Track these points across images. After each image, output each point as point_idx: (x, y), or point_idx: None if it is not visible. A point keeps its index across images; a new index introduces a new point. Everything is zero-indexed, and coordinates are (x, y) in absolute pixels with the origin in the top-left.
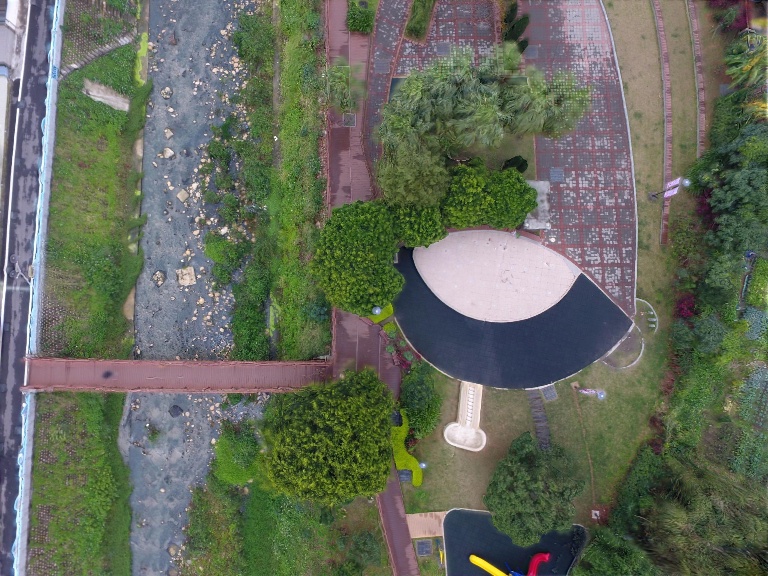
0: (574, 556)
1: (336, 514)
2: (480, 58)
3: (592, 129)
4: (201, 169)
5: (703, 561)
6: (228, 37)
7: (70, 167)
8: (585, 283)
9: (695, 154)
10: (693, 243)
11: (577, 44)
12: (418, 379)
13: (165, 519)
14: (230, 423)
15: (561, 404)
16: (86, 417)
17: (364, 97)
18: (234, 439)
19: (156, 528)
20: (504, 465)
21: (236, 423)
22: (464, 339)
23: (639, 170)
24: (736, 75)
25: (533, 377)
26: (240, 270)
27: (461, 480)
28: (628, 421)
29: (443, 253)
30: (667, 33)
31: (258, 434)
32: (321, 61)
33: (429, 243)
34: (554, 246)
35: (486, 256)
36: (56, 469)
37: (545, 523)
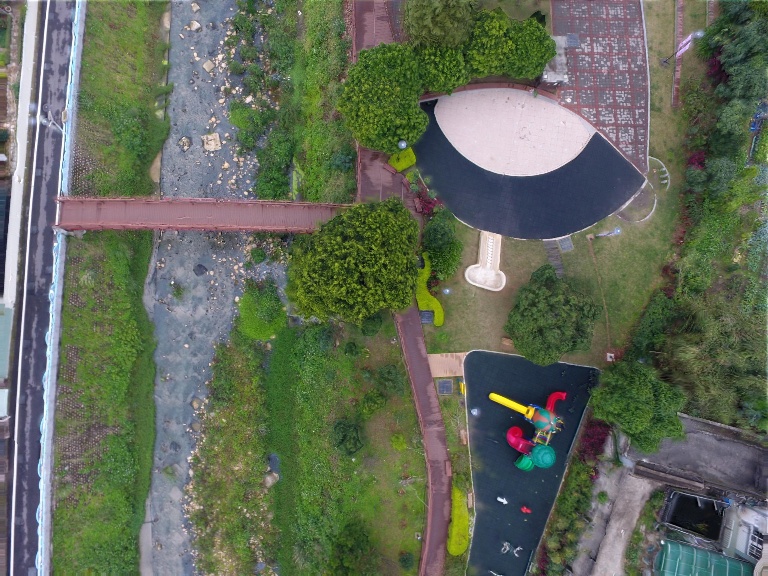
0: (590, 394)
1: (359, 354)
2: None
3: None
4: (227, 41)
5: (716, 383)
6: None
7: (102, 26)
8: (600, 141)
9: (704, 24)
10: (703, 103)
11: None
12: None
13: (189, 374)
14: (253, 281)
15: (577, 254)
16: (113, 269)
17: None
18: (258, 294)
19: (180, 383)
20: None
21: (259, 281)
22: (484, 191)
23: (651, 38)
24: None
25: (550, 228)
26: (264, 137)
27: (481, 321)
28: (642, 270)
29: (463, 110)
30: None
31: (281, 292)
32: None
33: (452, 87)
34: (570, 106)
35: (505, 114)
36: (84, 313)
37: (565, 342)
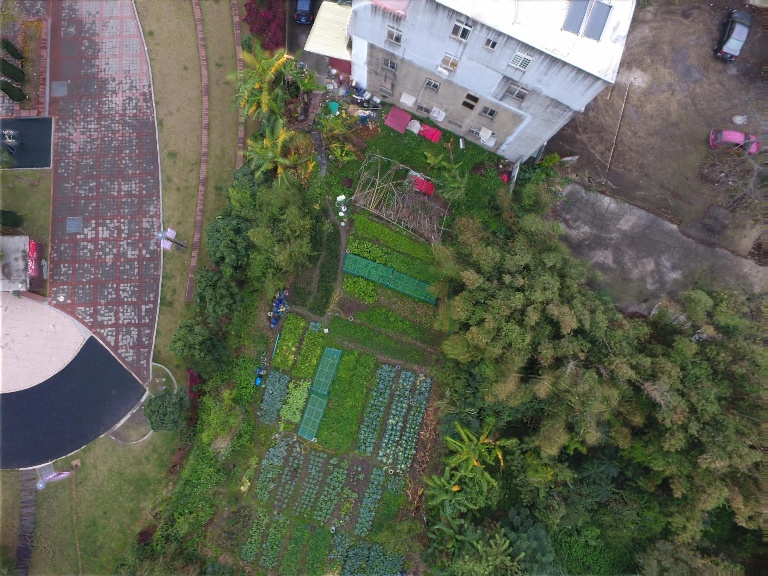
0: None
1: None
2: None
3: (119, 172)
4: None
5: None
6: None
7: None
8: (94, 347)
9: None
10: None
11: (111, 78)
12: None
13: None
14: None
15: (57, 486)
16: None
17: None
18: None
19: None
20: None
21: None
22: None
23: (168, 217)
24: None
25: (28, 455)
26: None
27: None
28: (127, 505)
29: None
30: (210, 62)
31: None
32: None
33: None
34: (62, 306)
35: None
36: None
37: None
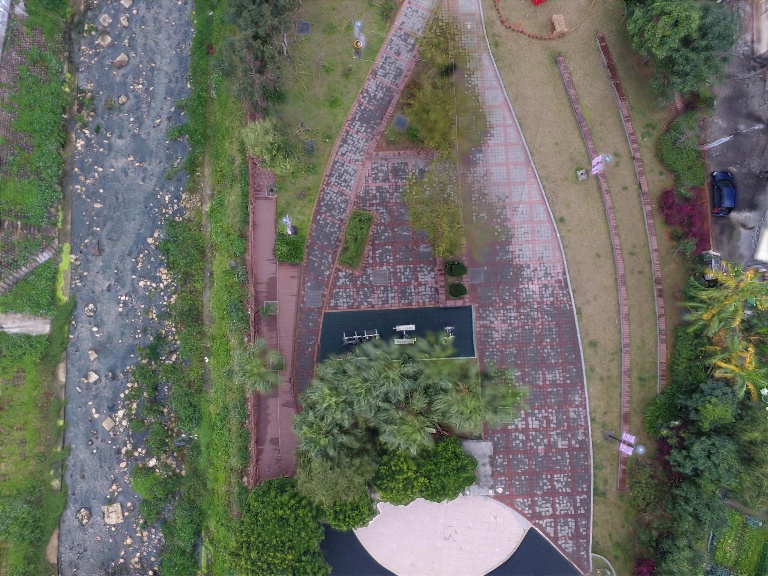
0: None
1: None
2: (420, 286)
3: (543, 361)
4: (127, 395)
5: None
6: (155, 246)
7: None
8: (536, 538)
9: (656, 388)
10: (653, 494)
11: (526, 265)
12: None
13: None
14: None
15: None
16: None
17: (293, 336)
18: None
19: None
20: None
21: None
22: None
23: (594, 407)
24: (696, 318)
25: None
26: (170, 506)
27: None
28: None
29: (380, 509)
30: (624, 251)
31: None
32: (247, 296)
33: None
34: (501, 497)
35: (427, 511)
36: None
37: None
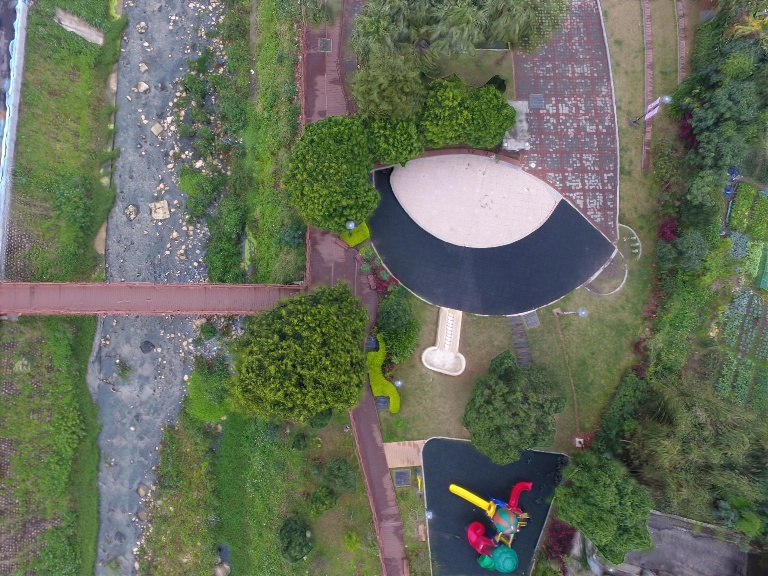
0: (558, 484)
1: (311, 444)
2: None
3: (572, 56)
4: (176, 102)
5: (690, 480)
6: None
7: (39, 93)
8: (566, 208)
9: (676, 81)
10: (675, 167)
11: None
12: (395, 302)
13: (135, 459)
14: (203, 358)
15: (543, 331)
16: (53, 350)
17: (340, 23)
18: (207, 374)
19: (125, 468)
20: (482, 381)
21: (209, 359)
22: (443, 264)
23: (620, 97)
24: None
25: (514, 303)
26: (215, 203)
27: (440, 407)
28: (612, 347)
29: (421, 178)
30: None
31: (232, 370)
32: None
33: (405, 159)
34: (534, 171)
35: (465, 181)
36: (19, 401)
37: (525, 439)
